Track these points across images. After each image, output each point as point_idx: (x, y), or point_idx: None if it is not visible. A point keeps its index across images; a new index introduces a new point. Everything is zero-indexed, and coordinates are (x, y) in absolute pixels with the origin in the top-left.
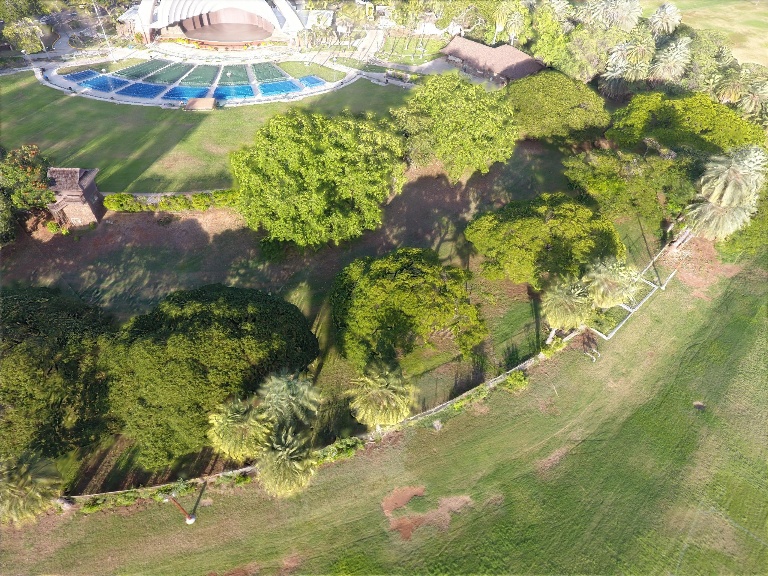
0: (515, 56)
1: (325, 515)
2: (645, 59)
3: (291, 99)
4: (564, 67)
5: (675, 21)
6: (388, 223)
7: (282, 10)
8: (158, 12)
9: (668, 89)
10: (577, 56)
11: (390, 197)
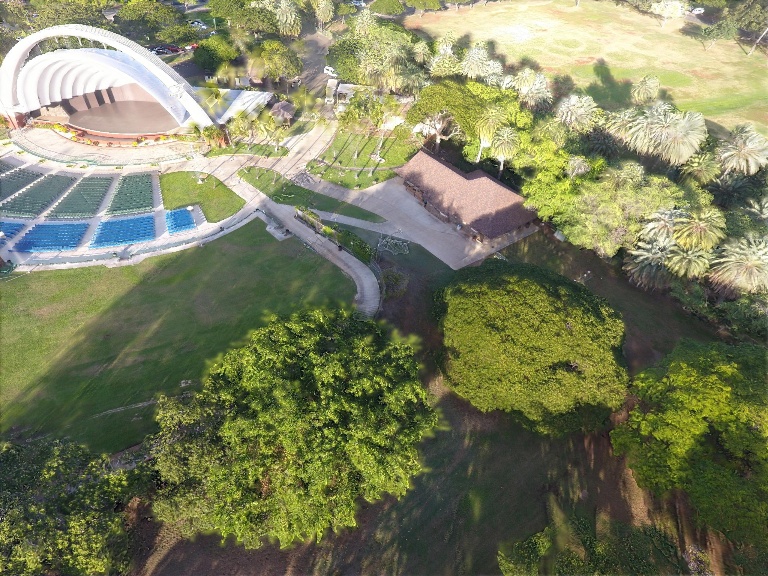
0: (496, 199)
1: None
2: (705, 244)
3: (124, 261)
4: (568, 232)
5: (761, 160)
6: None
7: (181, 100)
8: (17, 94)
9: (744, 315)
10: (588, 225)
11: None
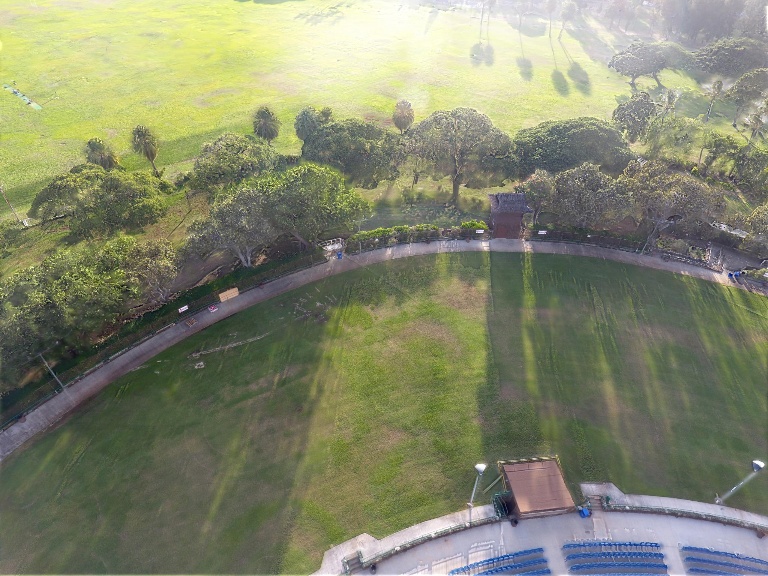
0: None
1: (299, 150)
2: None
3: (351, 554)
4: None
5: None
6: (227, 255)
7: None
8: None
9: None
10: None
11: (215, 272)
